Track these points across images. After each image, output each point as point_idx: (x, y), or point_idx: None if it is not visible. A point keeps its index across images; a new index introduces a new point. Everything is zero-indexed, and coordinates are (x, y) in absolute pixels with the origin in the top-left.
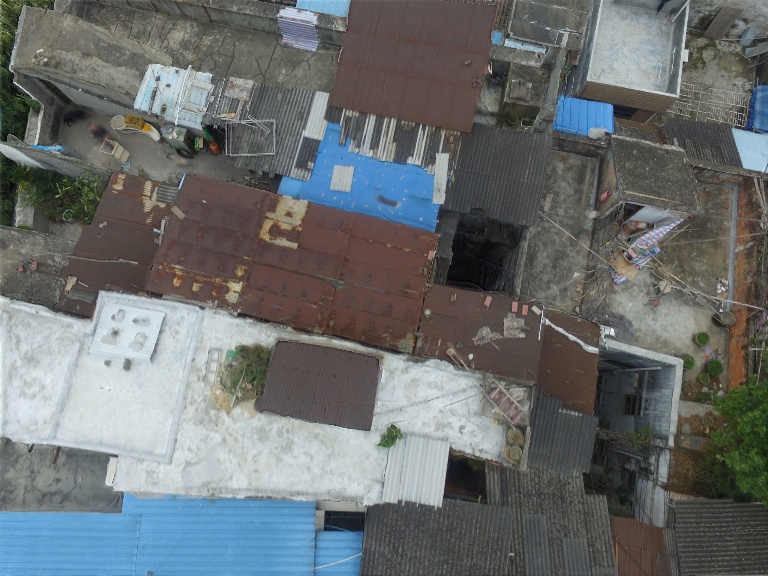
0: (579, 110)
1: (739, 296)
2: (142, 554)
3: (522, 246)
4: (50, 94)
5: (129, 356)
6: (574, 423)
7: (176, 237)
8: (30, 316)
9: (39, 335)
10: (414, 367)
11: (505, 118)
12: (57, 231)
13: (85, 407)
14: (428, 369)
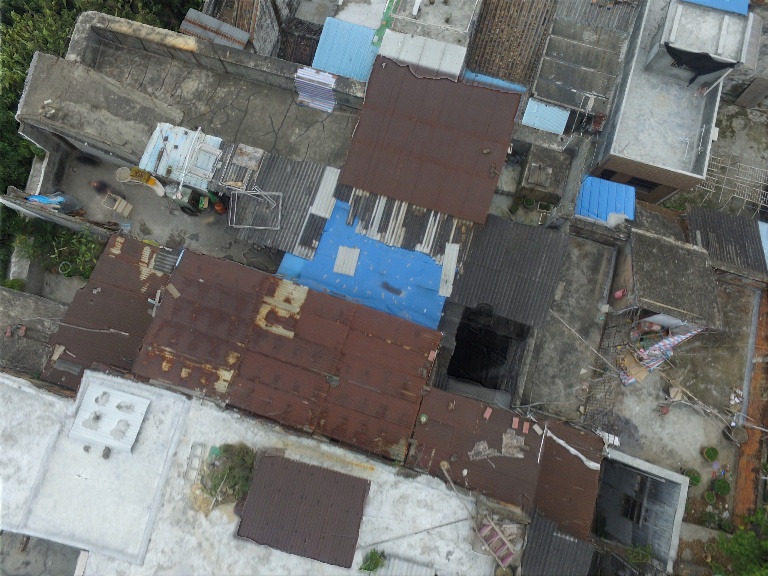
0: (600, 191)
1: (753, 412)
2: None
3: (529, 343)
4: (56, 140)
5: (109, 444)
6: (568, 548)
7: (169, 317)
8: (12, 390)
9: (19, 412)
10: (404, 482)
11: (522, 200)
12: (52, 282)
13: (60, 495)
14: (419, 485)
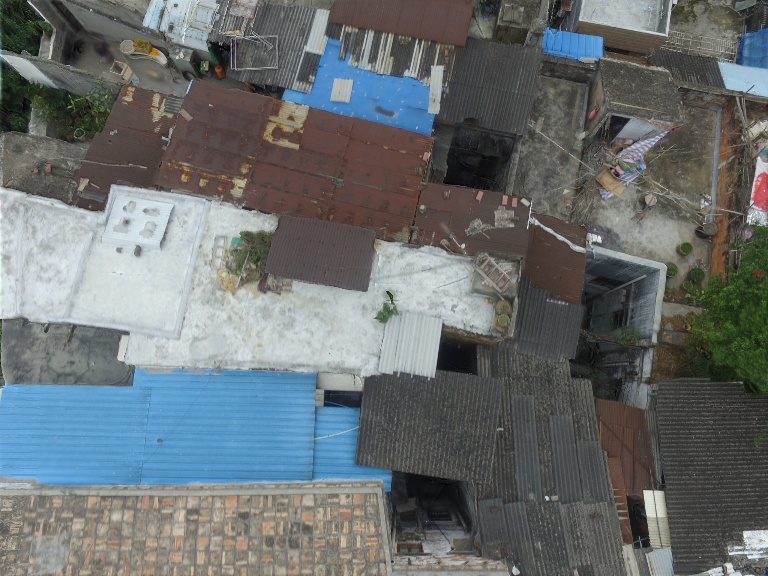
0: (570, 42)
1: (721, 208)
2: (152, 424)
3: (513, 158)
4: (62, 19)
5: (140, 242)
6: (561, 312)
7: (184, 137)
8: (45, 208)
9: (54, 225)
10: (409, 252)
11: (498, 43)
12: None
13: (98, 289)
14: (422, 254)
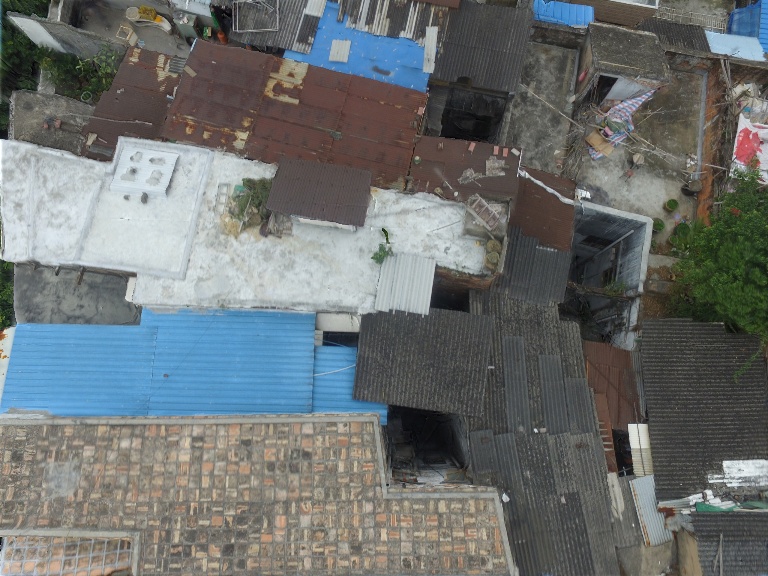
0: (562, 11)
1: (706, 165)
2: (159, 360)
3: (505, 116)
4: None
5: (146, 189)
6: (550, 258)
7: (188, 92)
8: (56, 159)
9: (64, 175)
10: (404, 198)
11: None
12: None
13: (107, 234)
14: (417, 200)
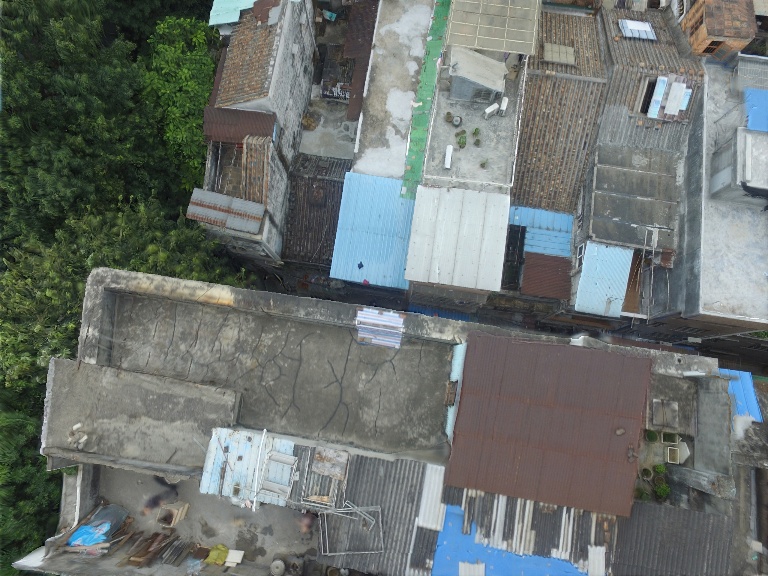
0: None
1: None
2: None
3: None
4: None
5: None
6: None
7: None
8: None
9: None
10: None
11: (642, 434)
12: None
13: None
14: None
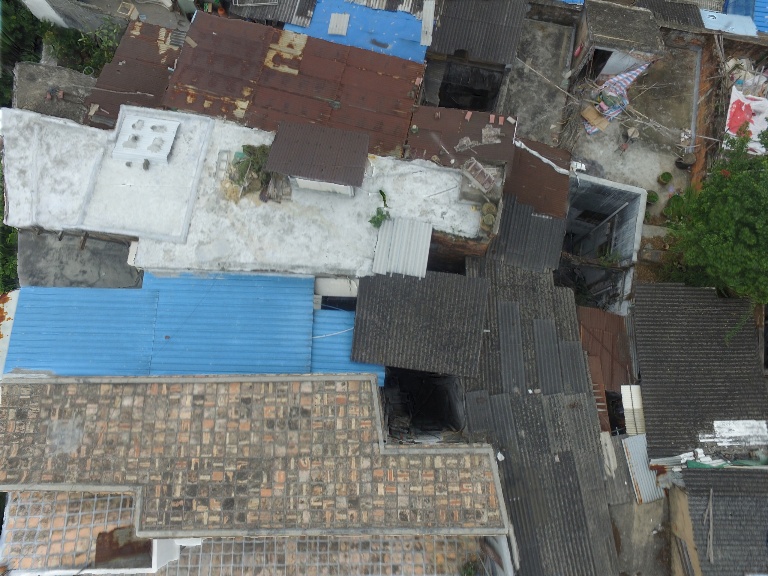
0: None
1: (699, 139)
2: (160, 322)
3: (502, 90)
4: None
5: (148, 156)
6: (545, 226)
7: (189, 62)
8: (59, 127)
9: (67, 142)
10: (401, 165)
11: None
12: None
13: (109, 200)
14: (414, 167)
